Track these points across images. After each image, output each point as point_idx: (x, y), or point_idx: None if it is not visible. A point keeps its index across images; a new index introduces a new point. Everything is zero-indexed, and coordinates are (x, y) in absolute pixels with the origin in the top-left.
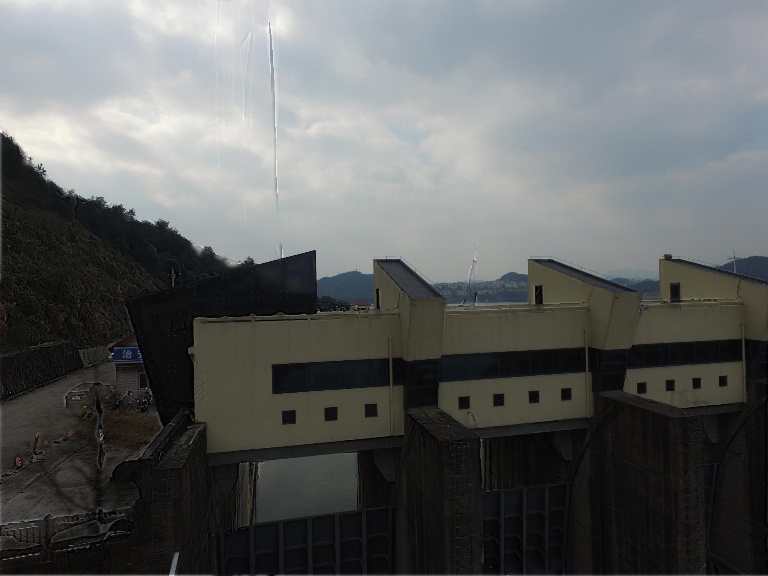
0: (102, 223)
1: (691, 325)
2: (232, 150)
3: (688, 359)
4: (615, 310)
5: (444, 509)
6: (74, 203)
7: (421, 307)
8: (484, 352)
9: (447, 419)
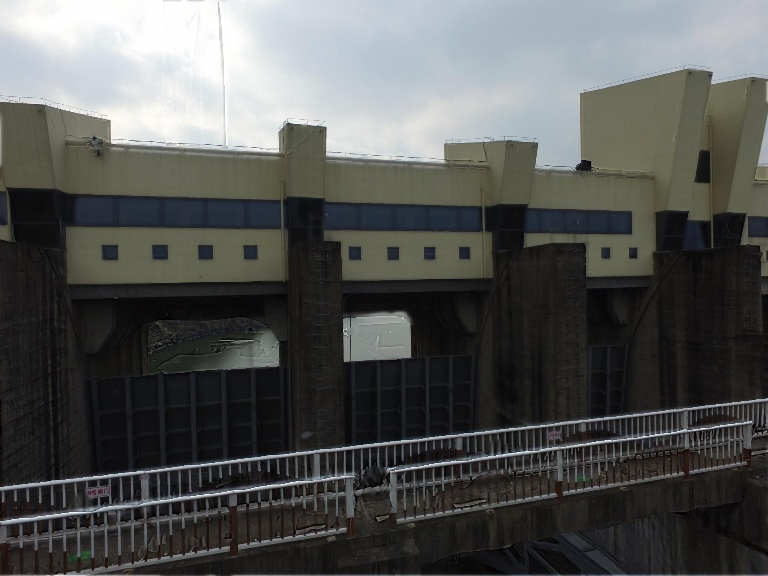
0: None
1: (198, 176)
2: (182, 134)
3: (198, 222)
4: (2, 127)
5: None
6: None
7: None
8: None
9: None
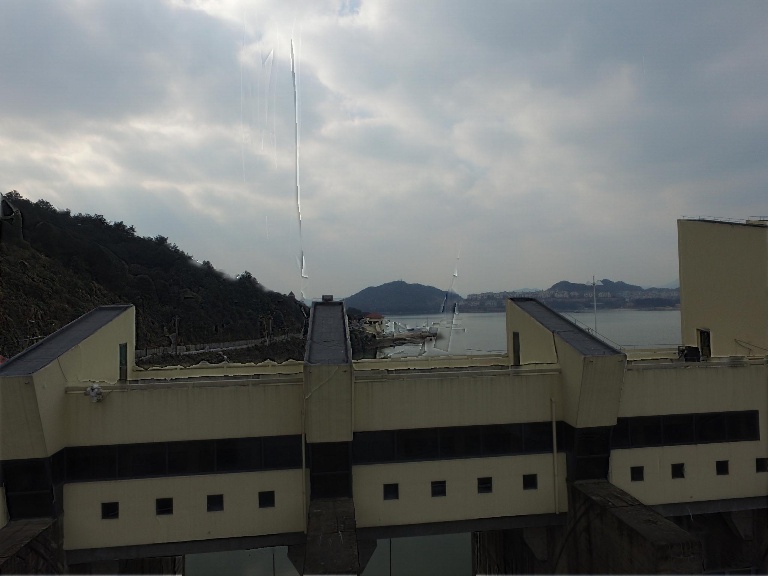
0: (58, 242)
1: (207, 414)
2: (257, 165)
3: (208, 465)
4: None
5: None
6: (19, 224)
7: None
8: None
9: None
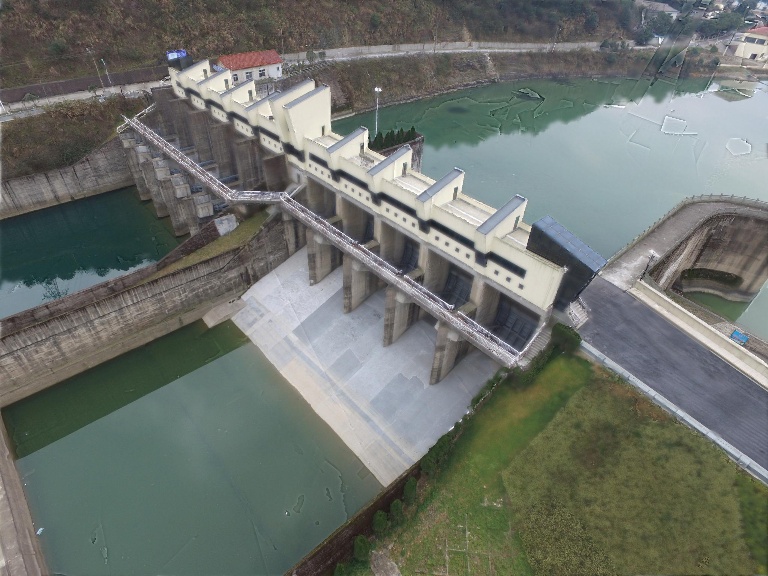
0: None
1: None
2: None
3: None
4: None
5: (170, 111)
6: None
7: (177, 76)
8: (194, 90)
9: (180, 99)
